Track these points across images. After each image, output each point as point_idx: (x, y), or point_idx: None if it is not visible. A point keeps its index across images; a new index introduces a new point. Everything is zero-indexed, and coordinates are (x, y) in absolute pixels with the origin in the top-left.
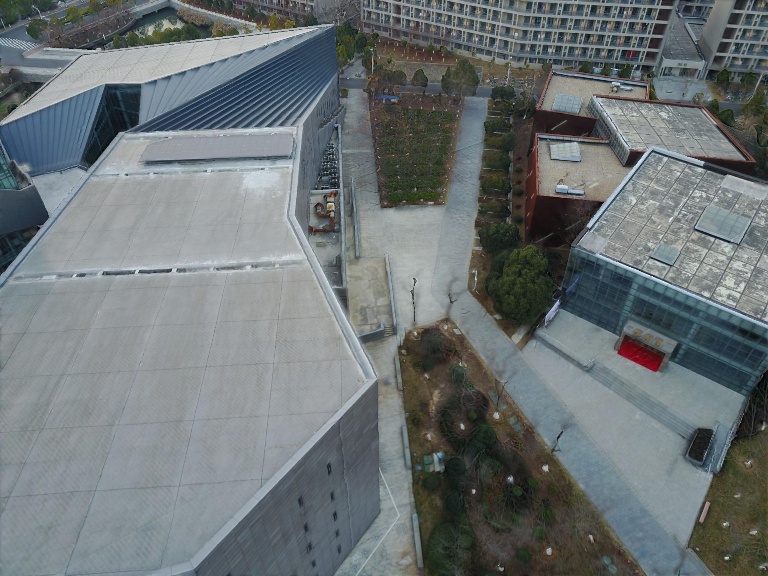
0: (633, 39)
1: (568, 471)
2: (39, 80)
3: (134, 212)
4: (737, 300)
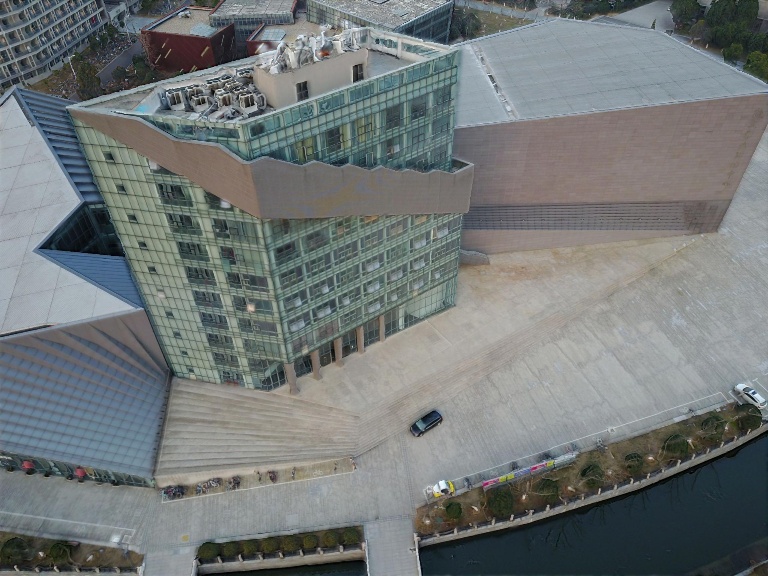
0: (88, 7)
1: None
2: None
3: None
4: (430, 6)
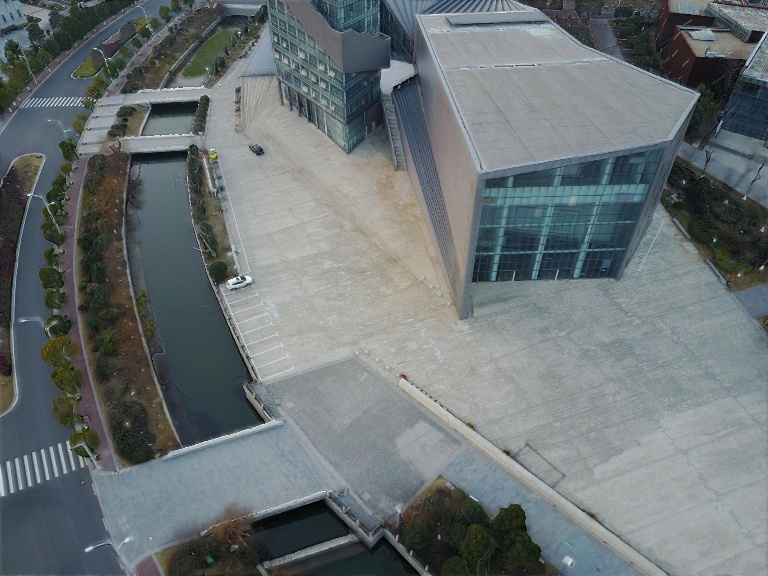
0: None
1: (757, 201)
2: (239, 13)
3: (478, 45)
4: None
